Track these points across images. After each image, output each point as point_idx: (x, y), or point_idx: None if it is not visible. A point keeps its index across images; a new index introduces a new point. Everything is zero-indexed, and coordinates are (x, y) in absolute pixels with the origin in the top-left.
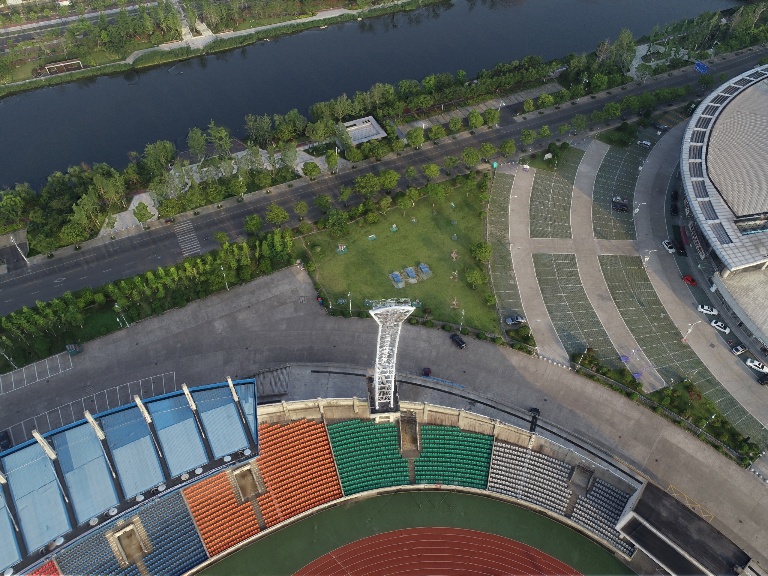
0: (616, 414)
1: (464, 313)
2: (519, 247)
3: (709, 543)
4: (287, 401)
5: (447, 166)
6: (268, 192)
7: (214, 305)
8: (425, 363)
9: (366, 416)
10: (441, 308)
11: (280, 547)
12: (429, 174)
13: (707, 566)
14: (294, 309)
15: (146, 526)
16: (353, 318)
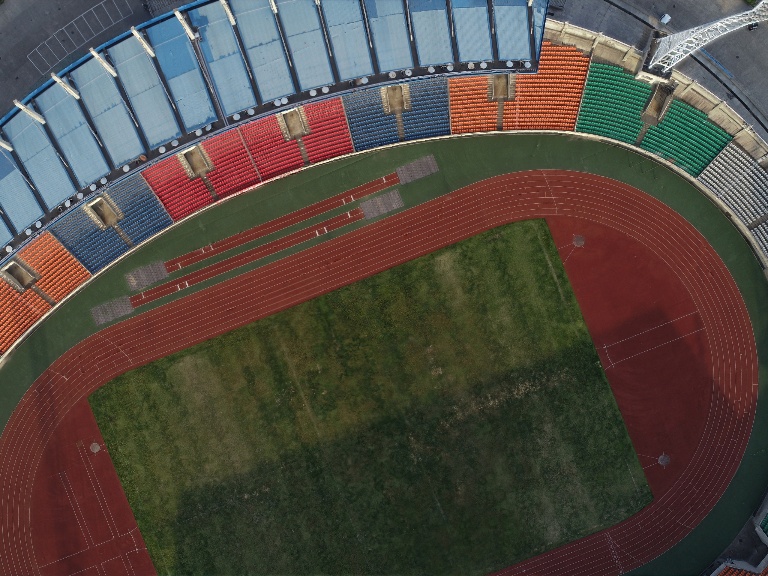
0: None
1: None
2: None
3: None
4: None
5: None
6: None
7: None
8: None
9: (630, 68)
10: None
11: (505, 148)
12: None
13: None
14: None
15: (411, 88)
16: None
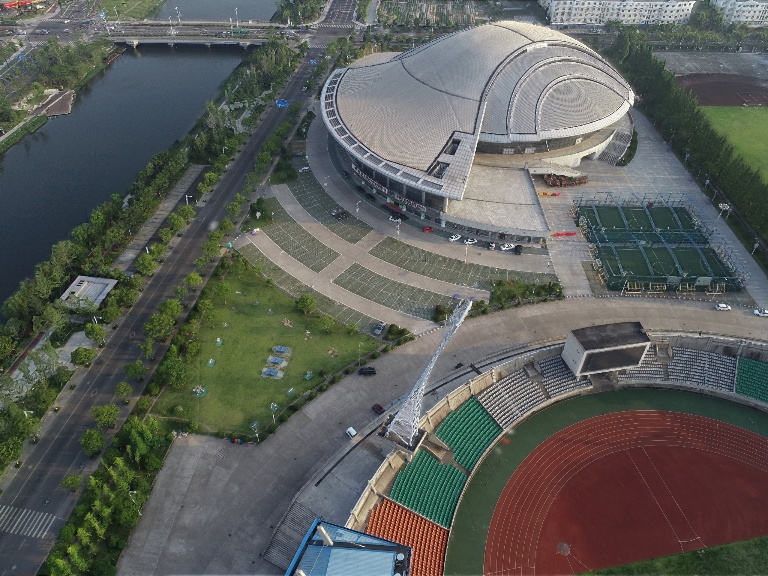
0: (491, 328)
1: (345, 352)
2: (331, 280)
3: (622, 332)
4: (353, 509)
5: (203, 267)
6: (56, 410)
7: (146, 540)
8: (367, 405)
9: (400, 464)
10: (328, 363)
11: None
12: (195, 283)
13: (634, 342)
14: (225, 468)
15: None
16: (280, 428)
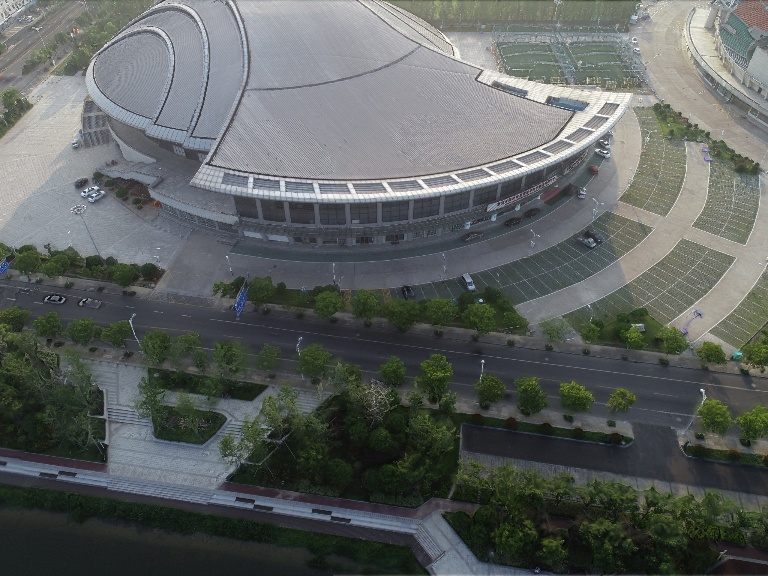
0: (741, 145)
1: None
2: None
3: None
4: None
5: None
6: None
7: None
8: None
9: None
10: None
11: None
12: None
13: None
14: None
15: None
16: None
